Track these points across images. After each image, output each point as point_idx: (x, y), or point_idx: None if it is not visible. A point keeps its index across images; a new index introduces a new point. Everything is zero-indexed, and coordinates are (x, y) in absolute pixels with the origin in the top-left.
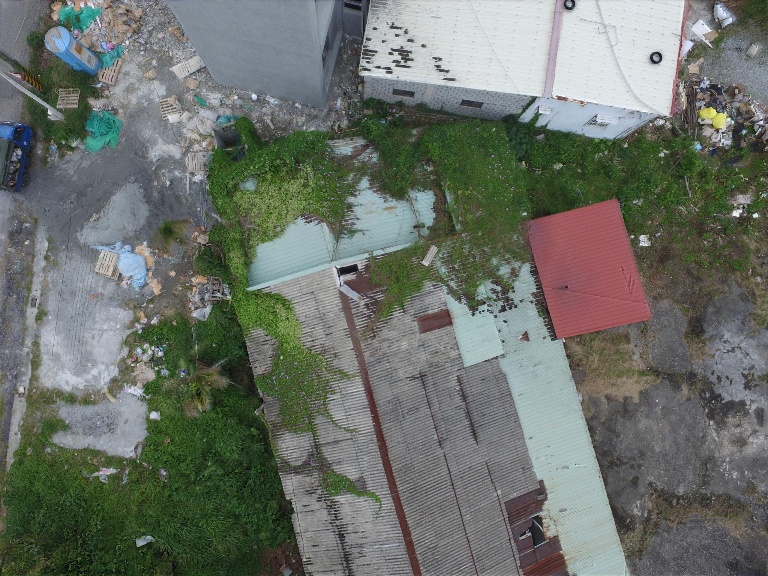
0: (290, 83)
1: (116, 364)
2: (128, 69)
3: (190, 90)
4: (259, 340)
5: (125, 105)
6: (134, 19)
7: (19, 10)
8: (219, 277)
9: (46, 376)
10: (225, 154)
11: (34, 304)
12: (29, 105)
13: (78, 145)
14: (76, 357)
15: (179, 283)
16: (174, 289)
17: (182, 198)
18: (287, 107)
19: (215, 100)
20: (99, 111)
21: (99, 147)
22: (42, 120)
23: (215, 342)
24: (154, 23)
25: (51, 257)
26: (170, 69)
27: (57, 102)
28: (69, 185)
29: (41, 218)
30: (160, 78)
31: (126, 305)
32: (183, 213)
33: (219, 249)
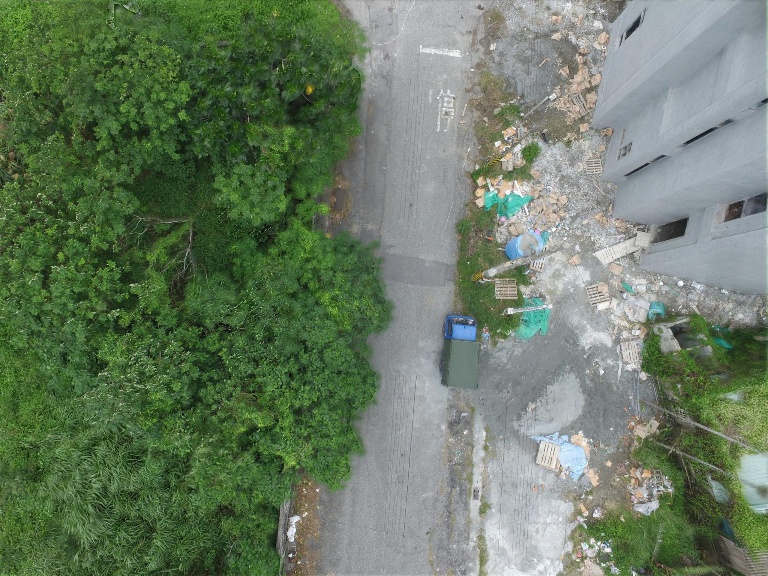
0: (754, 285)
1: (561, 559)
2: (553, 255)
3: (614, 276)
4: (765, 561)
5: (552, 291)
6: (560, 207)
7: (446, 198)
8: (660, 469)
9: (494, 572)
10: (688, 355)
11: (476, 496)
12: (466, 295)
13: (510, 333)
14: (522, 552)
15: (616, 474)
16: (611, 480)
17: (613, 386)
18: (713, 293)
19: (642, 286)
20: (527, 298)
21: (531, 335)
22: (480, 310)
23: (666, 540)
24: (577, 209)
25: (489, 447)
26: (593, 254)
27: (495, 293)
28: (503, 374)
29: (478, 407)
30: (584, 263)
31: (566, 497)
32: (614, 401)
33: (674, 447)
